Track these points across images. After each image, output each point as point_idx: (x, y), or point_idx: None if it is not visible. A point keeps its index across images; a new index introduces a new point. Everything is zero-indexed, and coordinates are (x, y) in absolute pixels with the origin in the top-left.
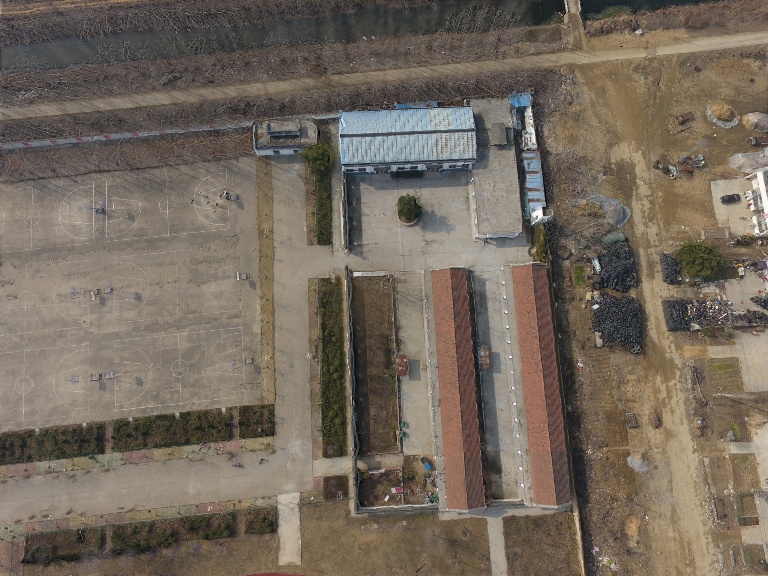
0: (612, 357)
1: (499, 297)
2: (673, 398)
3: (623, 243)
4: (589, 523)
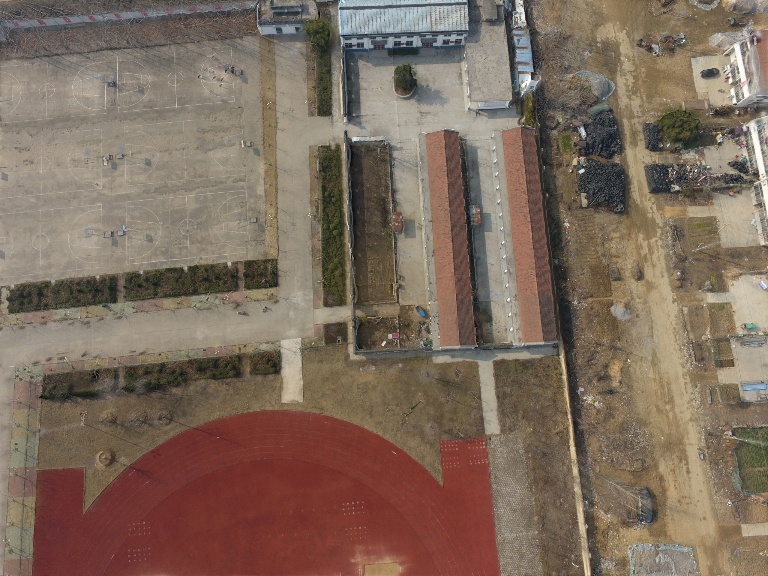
0: (597, 217)
1: (490, 163)
2: (654, 253)
3: (608, 112)
4: (574, 366)
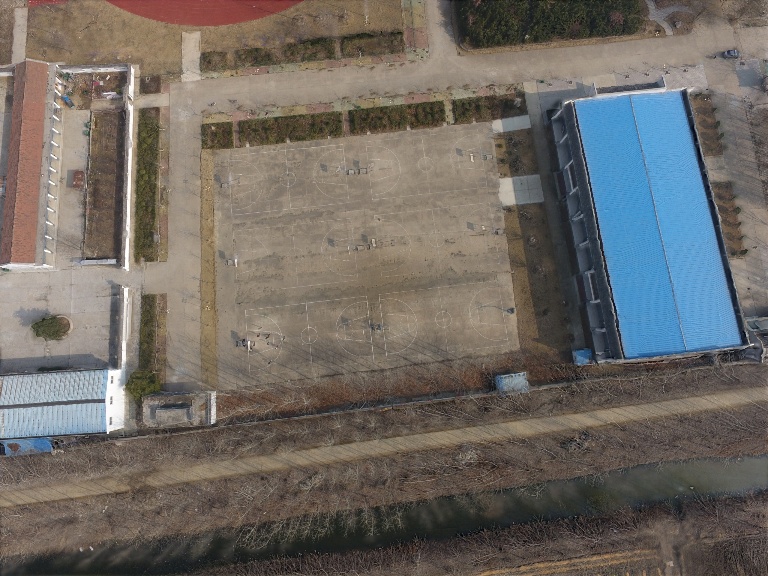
0: None
1: None
2: None
3: None
4: None
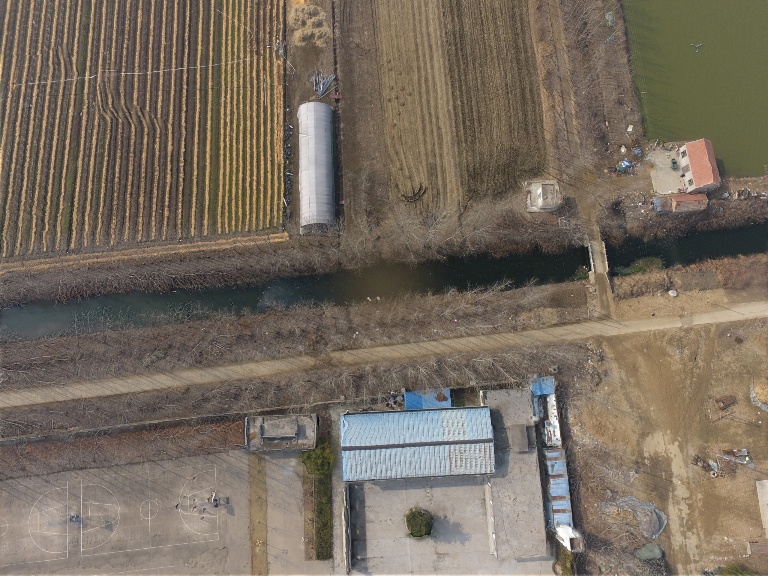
0: None
1: None
2: None
3: (659, 562)
4: None
